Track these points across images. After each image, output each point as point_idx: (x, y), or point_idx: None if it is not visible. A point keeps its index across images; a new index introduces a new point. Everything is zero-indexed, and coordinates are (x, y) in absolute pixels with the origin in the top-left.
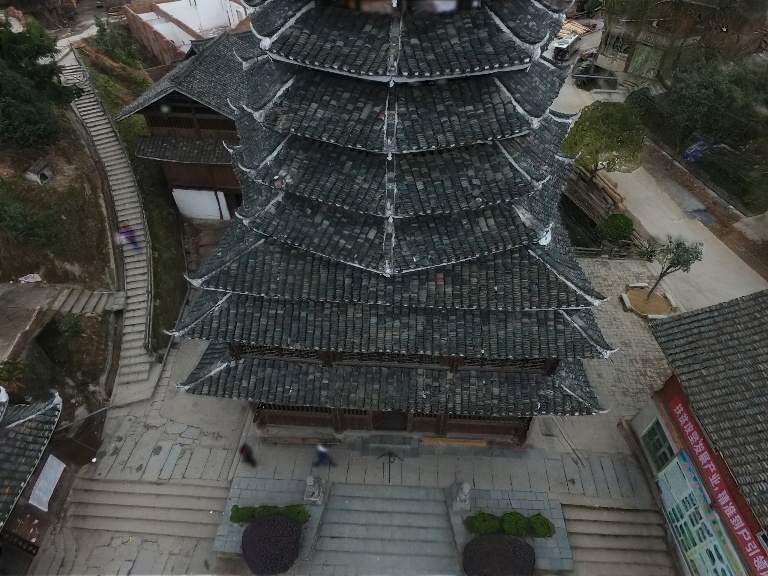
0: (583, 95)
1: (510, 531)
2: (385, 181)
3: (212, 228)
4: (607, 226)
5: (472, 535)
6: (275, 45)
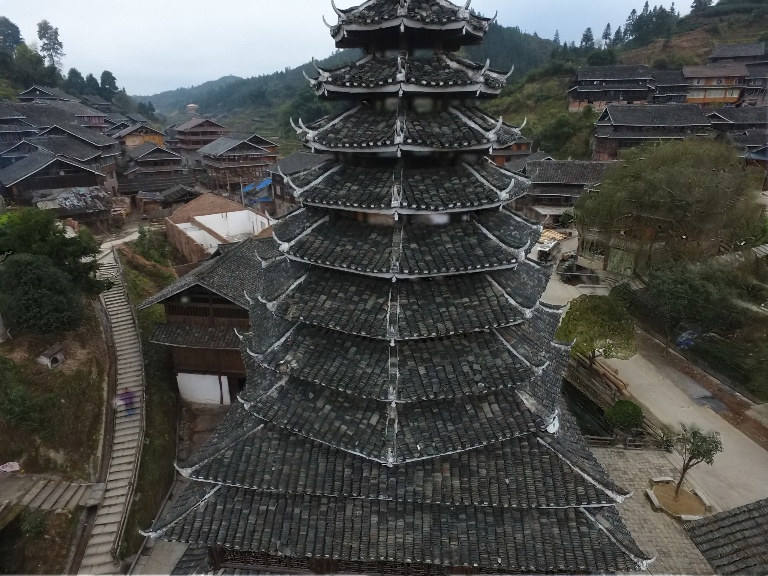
0: (570, 289)
1: None
2: (388, 366)
3: (210, 413)
4: (616, 413)
5: None
6: (292, 248)
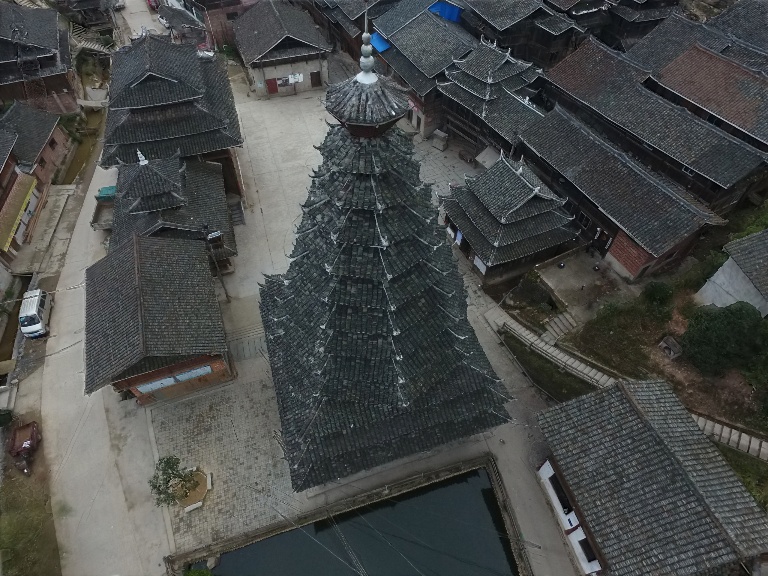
0: None
1: None
2: None
3: None
4: None
5: None
6: None
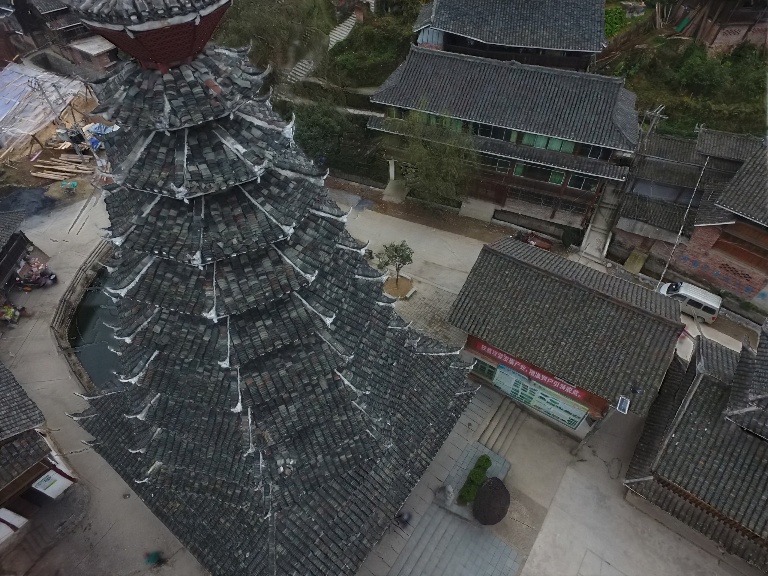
0: None
1: (481, 482)
2: (354, 405)
3: (11, 549)
4: None
5: (468, 505)
6: (247, 403)
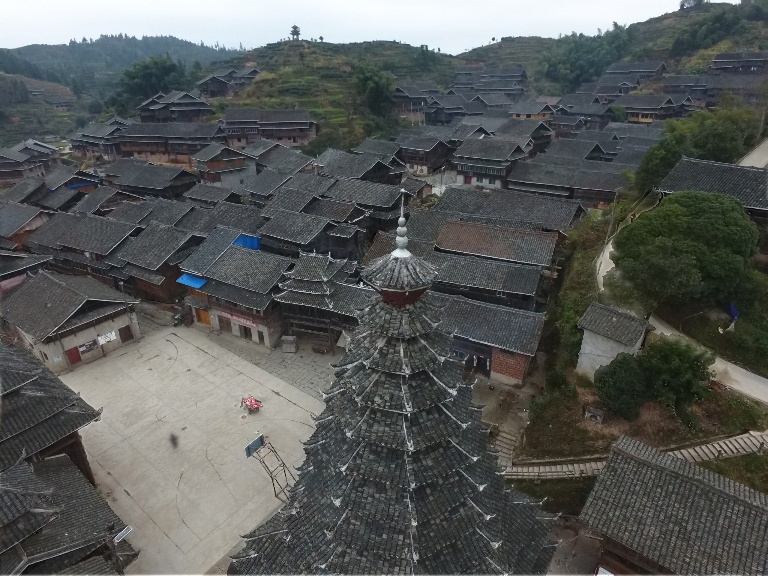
0: None
1: None
2: None
3: None
4: None
5: None
6: None
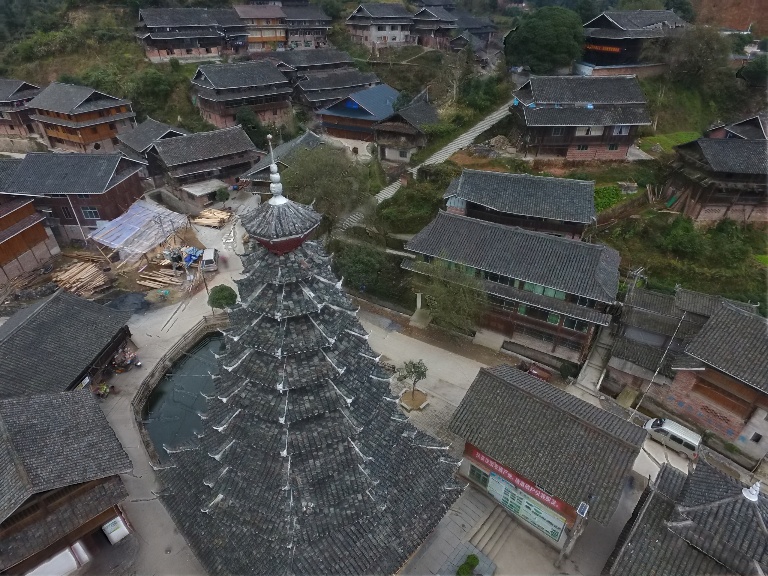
0: None
1: None
2: (361, 470)
3: None
4: None
5: None
6: (290, 450)
